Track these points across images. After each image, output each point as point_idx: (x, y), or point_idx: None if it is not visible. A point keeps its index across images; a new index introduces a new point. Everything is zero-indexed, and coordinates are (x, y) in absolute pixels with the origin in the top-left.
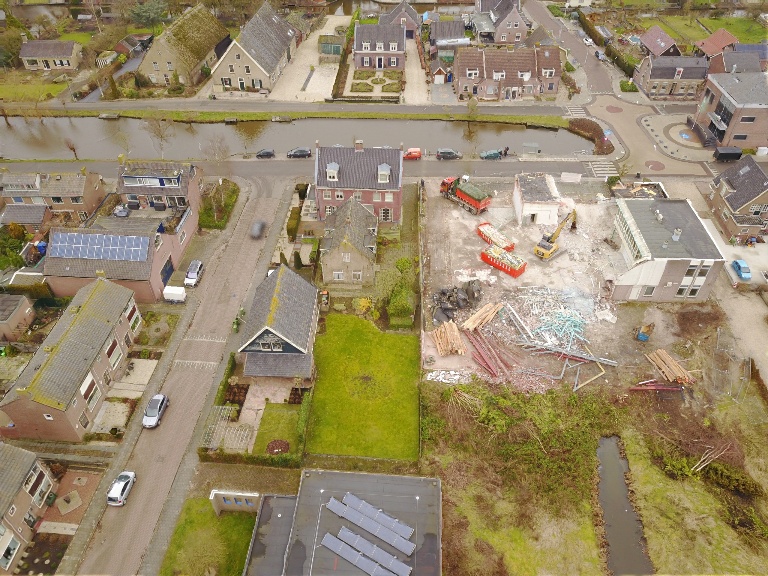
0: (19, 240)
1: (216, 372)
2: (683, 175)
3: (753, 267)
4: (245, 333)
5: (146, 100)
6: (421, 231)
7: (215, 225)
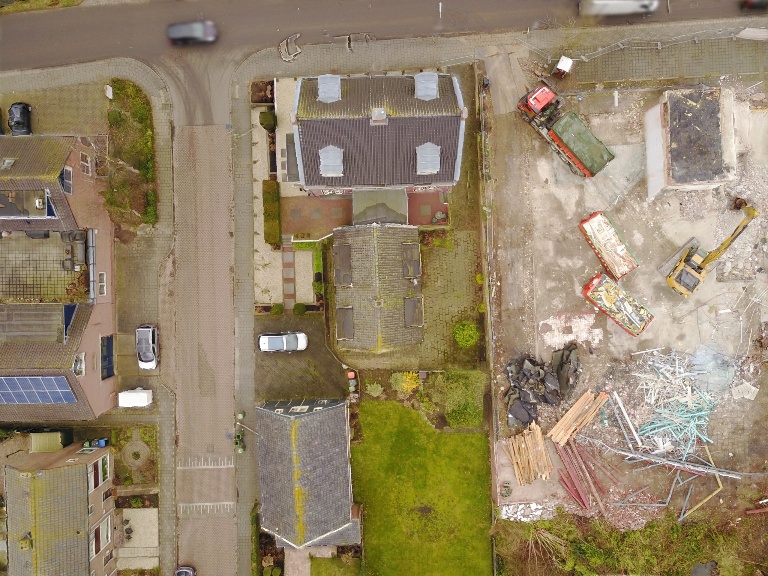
0: None
1: (236, 516)
2: None
3: None
4: (265, 505)
5: None
6: (486, 223)
7: (140, 220)
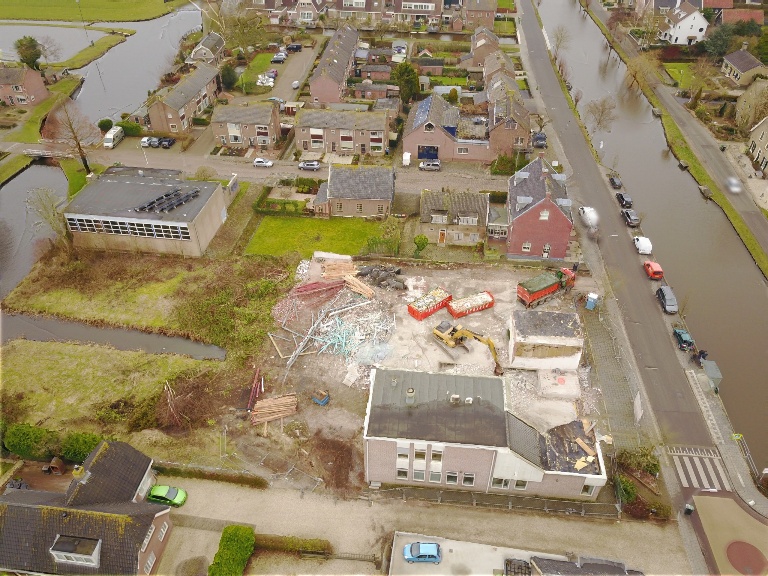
0: (449, 99)
1: None
2: None
3: None
4: None
5: (697, 121)
6: (488, 263)
7: (492, 168)
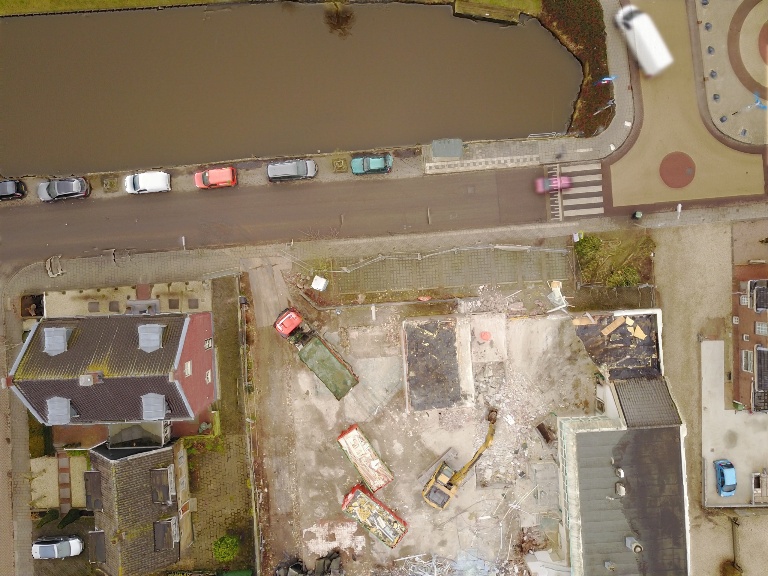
0: None
1: None
2: (720, 201)
3: (746, 461)
4: None
5: None
6: (250, 434)
7: None
